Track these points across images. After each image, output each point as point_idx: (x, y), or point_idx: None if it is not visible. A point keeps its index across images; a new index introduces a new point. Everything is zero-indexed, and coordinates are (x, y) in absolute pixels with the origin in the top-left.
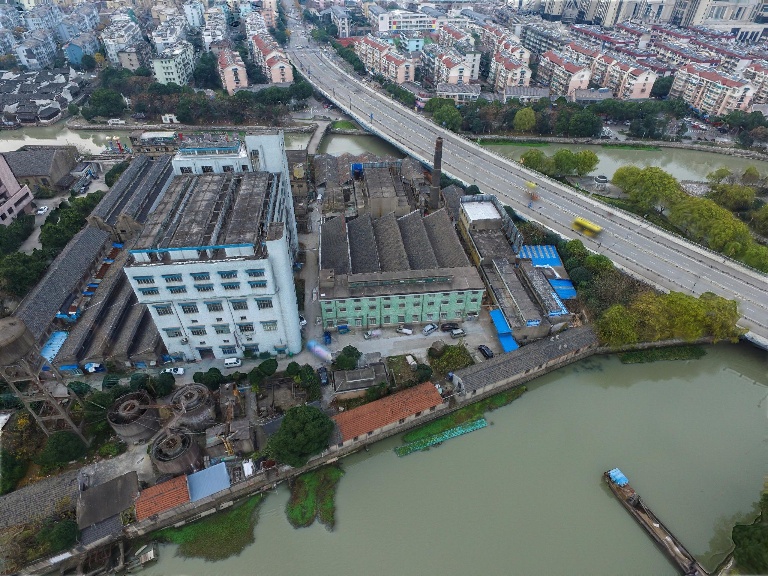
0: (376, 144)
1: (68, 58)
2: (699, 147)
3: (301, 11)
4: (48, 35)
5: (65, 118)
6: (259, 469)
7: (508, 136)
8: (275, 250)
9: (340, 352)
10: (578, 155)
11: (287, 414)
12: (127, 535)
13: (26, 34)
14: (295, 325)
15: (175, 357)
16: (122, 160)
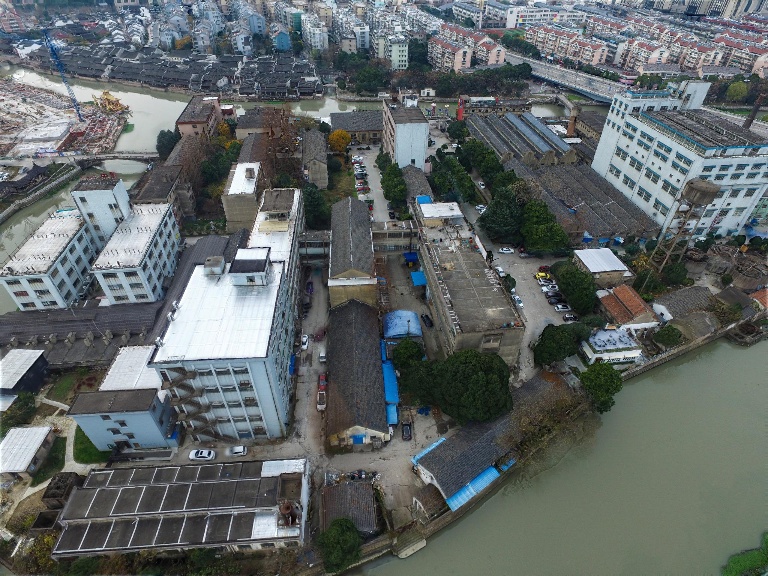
0: None
1: (276, 45)
2: None
3: (418, 6)
4: None
5: (326, 93)
6: None
7: (720, 105)
8: None
9: None
10: None
11: None
12: (751, 319)
13: (233, 24)
14: None
15: (668, 235)
16: (447, 120)
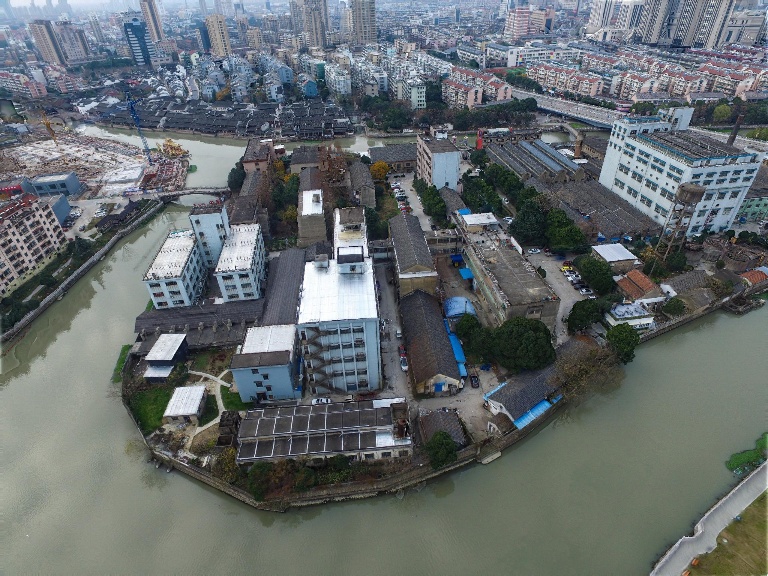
0: None
1: (305, 92)
2: None
3: None
4: None
5: (356, 132)
6: None
7: None
8: (762, 158)
9: None
10: None
11: None
12: (742, 294)
13: (266, 76)
14: (737, 211)
15: (669, 233)
16: (469, 149)
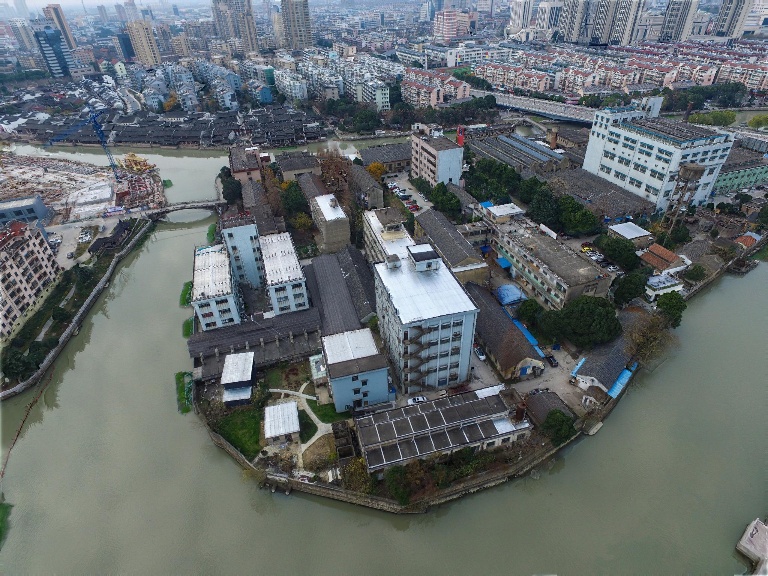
0: (569, 127)
1: (260, 99)
2: (764, 108)
3: None
4: (229, 83)
5: (326, 136)
6: (763, 233)
7: None
8: None
9: (734, 198)
10: (724, 113)
11: (767, 207)
12: None
13: (216, 84)
14: None
15: (661, 210)
16: None
